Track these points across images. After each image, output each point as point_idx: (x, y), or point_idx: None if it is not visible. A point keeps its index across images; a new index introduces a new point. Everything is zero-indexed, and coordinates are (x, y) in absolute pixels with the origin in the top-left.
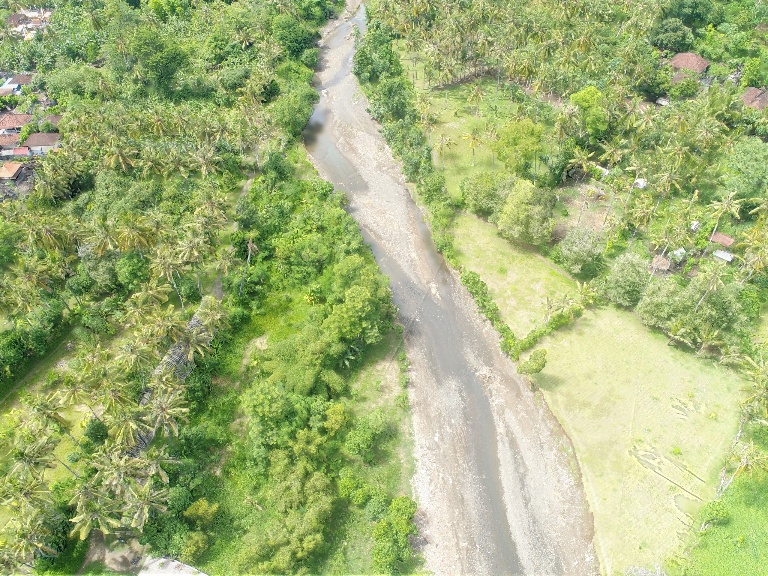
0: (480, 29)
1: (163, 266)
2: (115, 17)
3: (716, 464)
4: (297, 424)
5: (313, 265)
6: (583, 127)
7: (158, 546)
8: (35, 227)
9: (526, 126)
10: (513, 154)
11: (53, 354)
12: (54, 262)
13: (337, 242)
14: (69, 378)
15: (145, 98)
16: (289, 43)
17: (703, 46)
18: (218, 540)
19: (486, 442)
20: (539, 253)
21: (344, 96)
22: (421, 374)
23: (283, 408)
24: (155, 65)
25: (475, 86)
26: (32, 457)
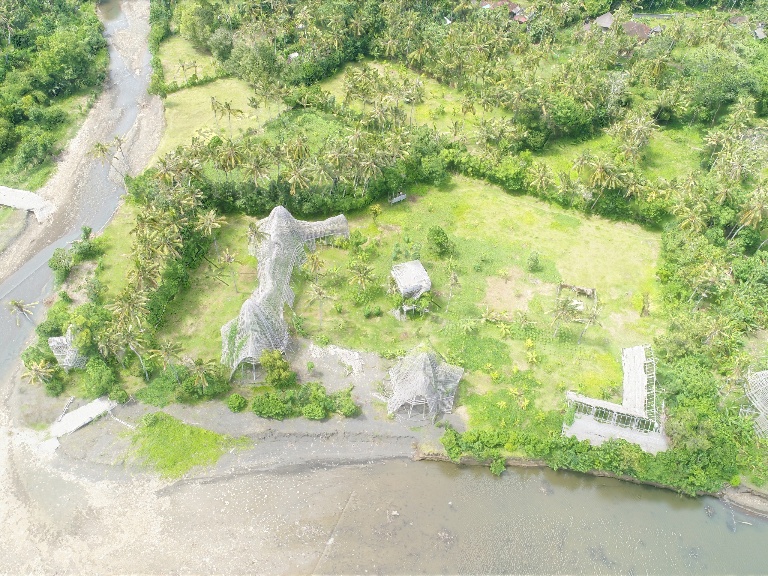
0: None
1: None
2: None
3: None
4: None
5: None
6: None
7: None
8: None
9: None
10: None
11: None
12: None
13: None
14: None
15: None
16: None
17: None
18: None
19: (123, 130)
20: (211, 55)
21: None
22: (104, 104)
23: None
24: None
25: None
26: None
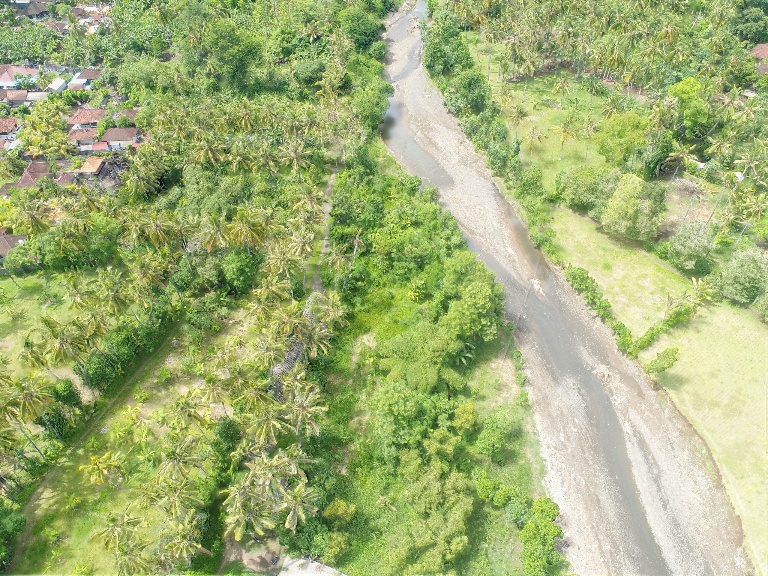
0: (559, 20)
1: (283, 262)
2: (184, 11)
3: None
4: (427, 423)
5: (415, 261)
6: (679, 119)
7: (299, 547)
8: (138, 222)
9: (632, 118)
10: (618, 147)
11: (160, 351)
12: (164, 258)
13: (435, 237)
14: (211, 376)
15: (217, 92)
16: (358, 36)
17: None
18: (355, 541)
19: (614, 442)
20: (642, 248)
21: (416, 89)
22: (536, 372)
23: (415, 407)
24: (231, 59)
25: (561, 78)
26: (181, 456)
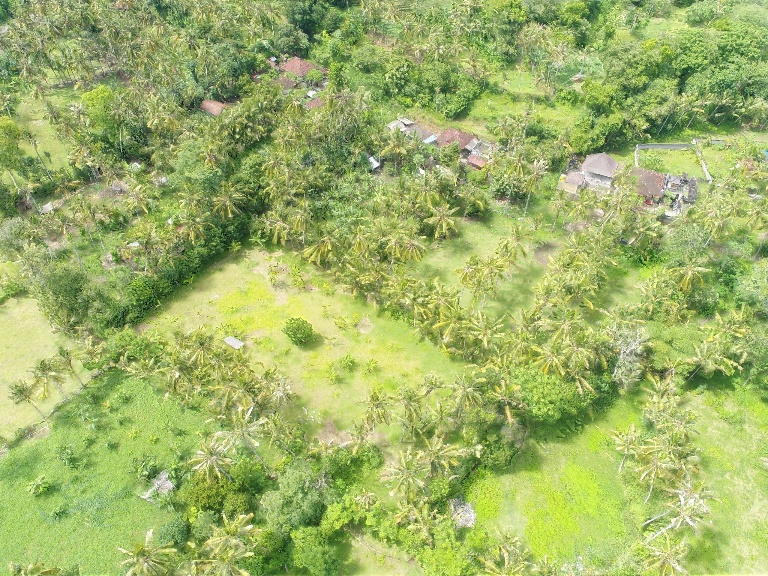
0: None
1: None
2: None
3: (7, 441)
4: None
5: None
6: None
7: None
8: None
9: None
10: None
11: None
12: None
13: None
14: None
15: None
16: None
17: (313, 51)
18: None
19: None
20: None
21: None
22: None
23: None
24: None
25: (34, 84)
26: None
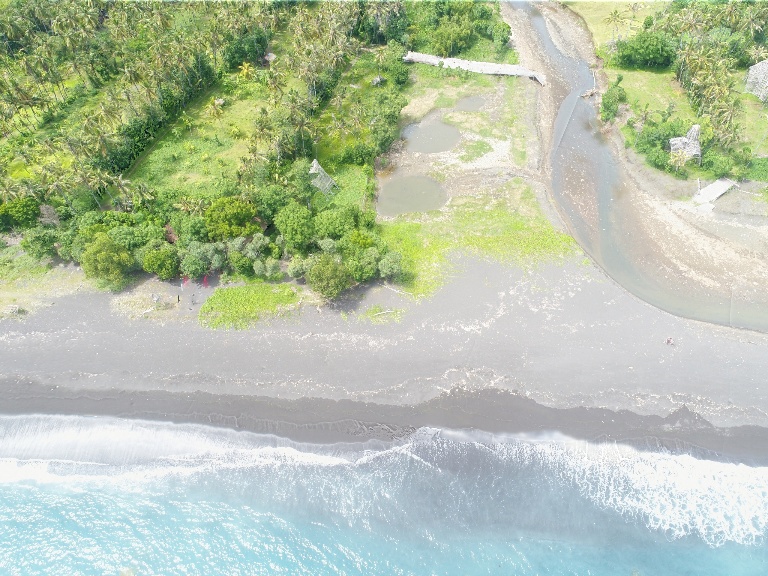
0: None
1: None
2: None
3: None
4: None
5: None
6: None
7: (396, 40)
8: None
9: None
10: None
11: (313, 6)
12: None
13: None
14: None
15: None
16: None
17: None
18: (419, 46)
19: (540, 24)
20: None
21: None
22: (505, 8)
23: None
24: None
25: None
26: None
